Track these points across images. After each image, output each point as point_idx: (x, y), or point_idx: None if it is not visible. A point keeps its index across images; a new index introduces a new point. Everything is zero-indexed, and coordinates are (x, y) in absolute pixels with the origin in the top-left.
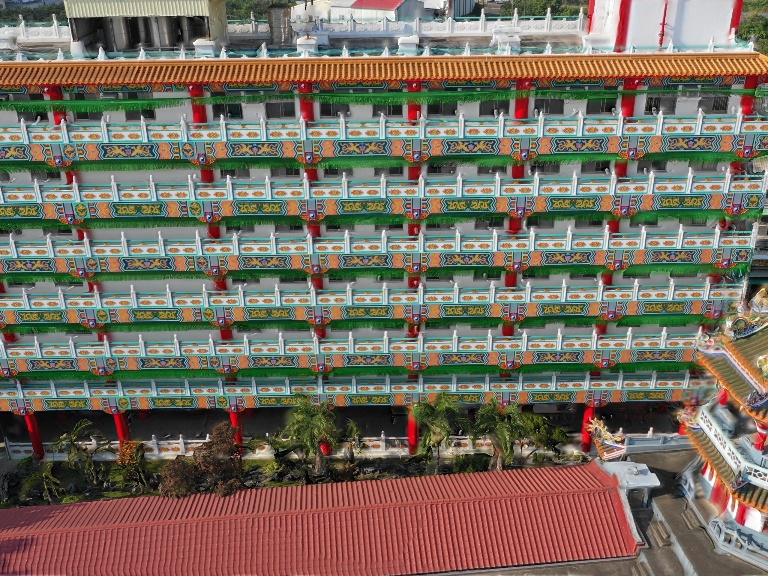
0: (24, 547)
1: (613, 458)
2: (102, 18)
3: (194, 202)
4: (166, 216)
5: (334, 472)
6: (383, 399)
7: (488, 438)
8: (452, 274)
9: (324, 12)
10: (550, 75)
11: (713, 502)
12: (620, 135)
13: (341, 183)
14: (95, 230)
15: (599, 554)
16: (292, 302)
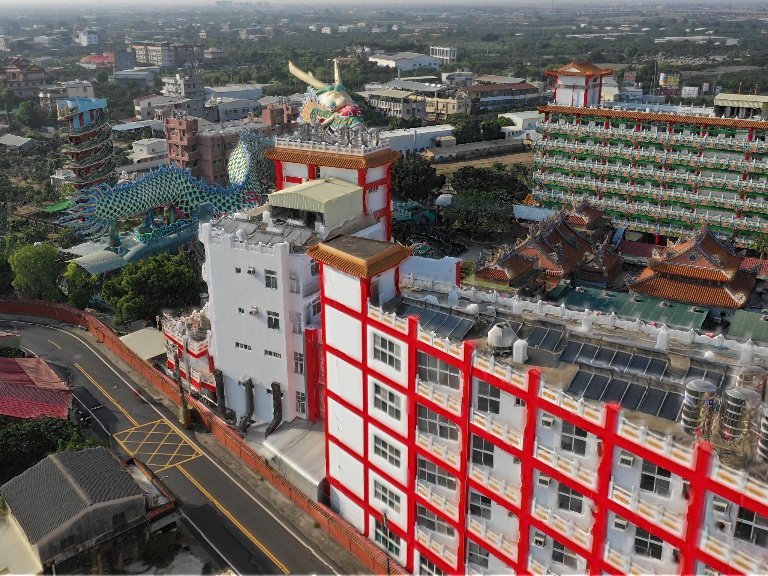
0: (665, 249)
1: None
2: (724, 106)
3: (741, 166)
4: (730, 169)
5: None
6: None
7: None
8: None
9: None
10: None
11: None
12: None
13: None
14: (704, 171)
15: None
16: (767, 207)
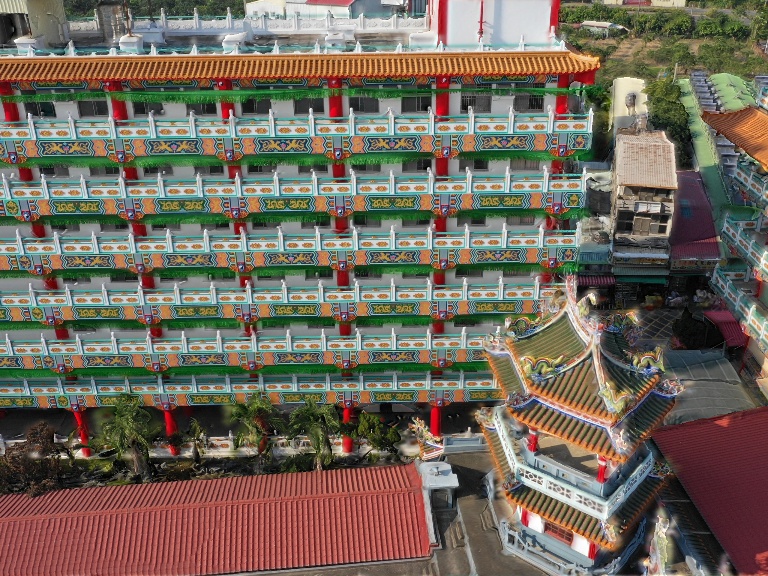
0: None
1: (431, 458)
2: None
3: (10, 201)
4: None
5: (169, 472)
6: (224, 398)
7: (337, 437)
8: (283, 273)
9: (280, 8)
10: (355, 73)
11: (510, 503)
12: (432, 134)
13: (157, 182)
14: None
15: (393, 555)
16: (120, 301)
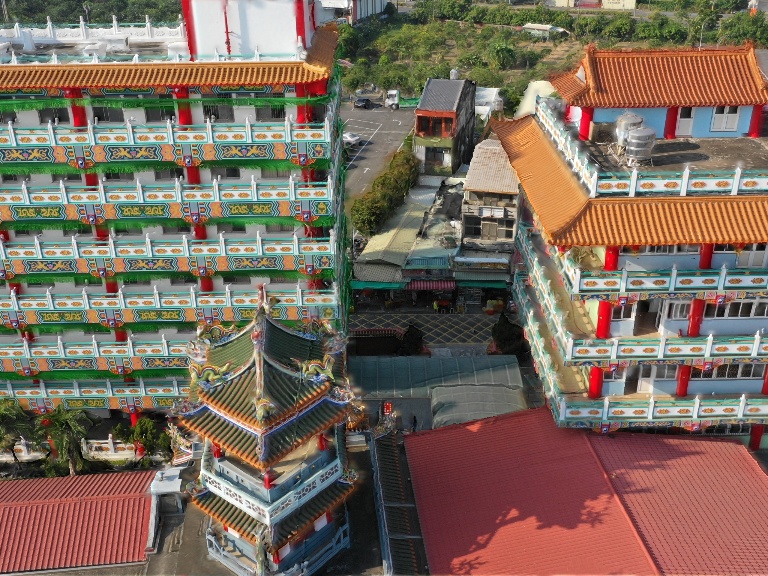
0: None
1: (180, 463)
2: None
3: None
4: None
5: None
6: None
7: None
8: (52, 280)
9: None
10: (86, 84)
11: None
12: (172, 143)
13: None
14: None
15: (109, 560)
16: None
